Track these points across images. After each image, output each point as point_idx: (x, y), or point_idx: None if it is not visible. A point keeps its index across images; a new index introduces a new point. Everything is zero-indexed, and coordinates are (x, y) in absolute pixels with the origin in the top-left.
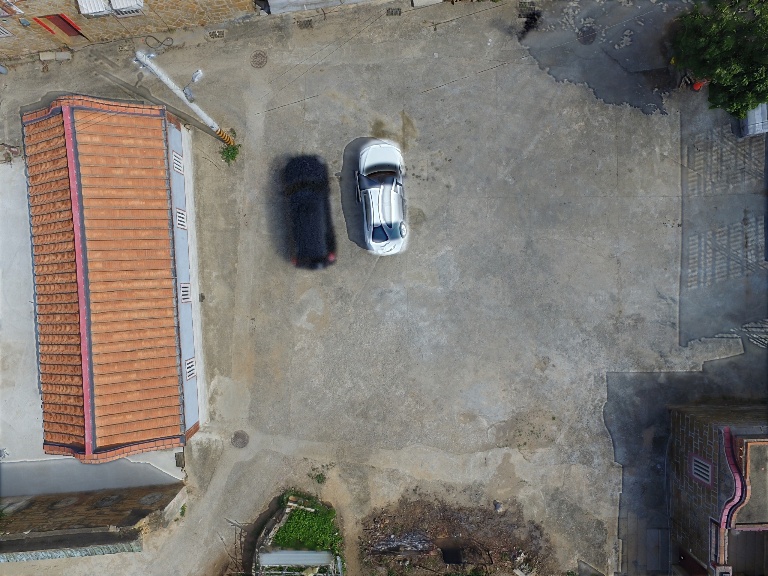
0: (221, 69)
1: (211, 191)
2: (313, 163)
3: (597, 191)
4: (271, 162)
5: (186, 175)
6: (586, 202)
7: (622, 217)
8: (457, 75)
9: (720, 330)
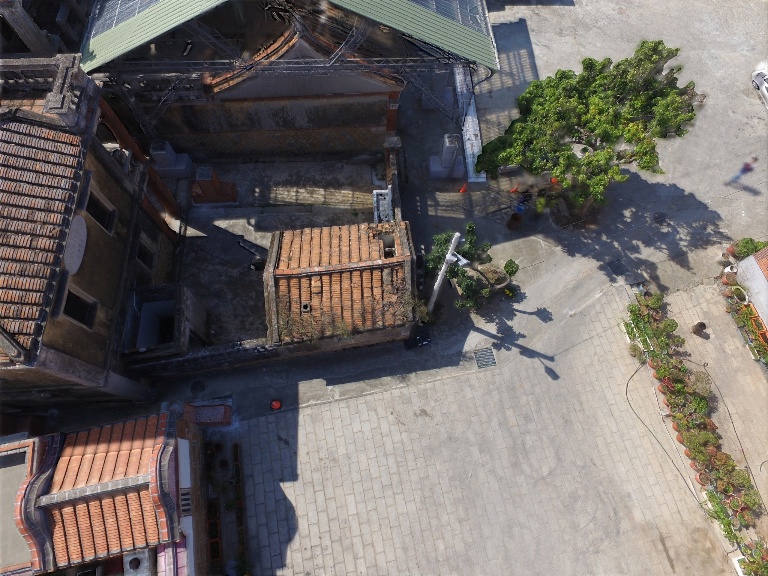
0: None
1: None
2: None
3: None
4: None
5: None
6: None
7: None
8: (760, 188)
9: (496, 28)
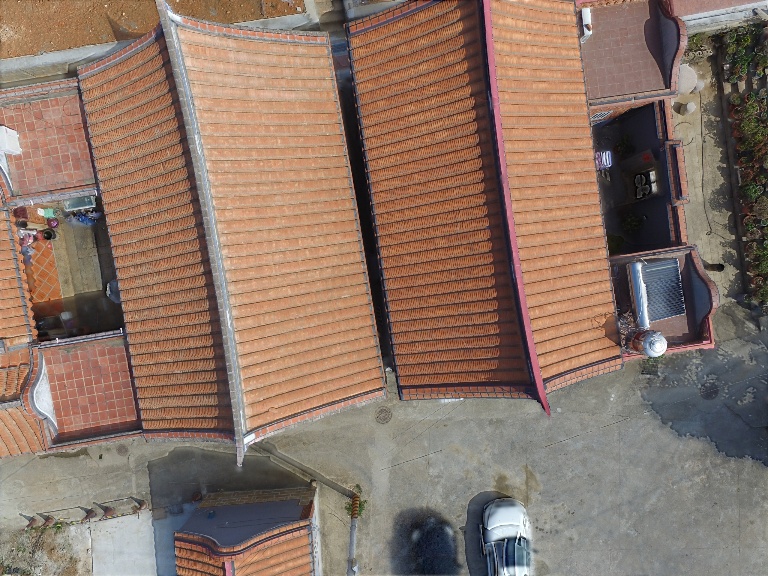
0: (346, 425)
1: (338, 547)
2: (438, 517)
3: (719, 542)
4: (396, 517)
5: (318, 545)
6: (708, 553)
7: (744, 568)
8: (580, 430)
9: None
